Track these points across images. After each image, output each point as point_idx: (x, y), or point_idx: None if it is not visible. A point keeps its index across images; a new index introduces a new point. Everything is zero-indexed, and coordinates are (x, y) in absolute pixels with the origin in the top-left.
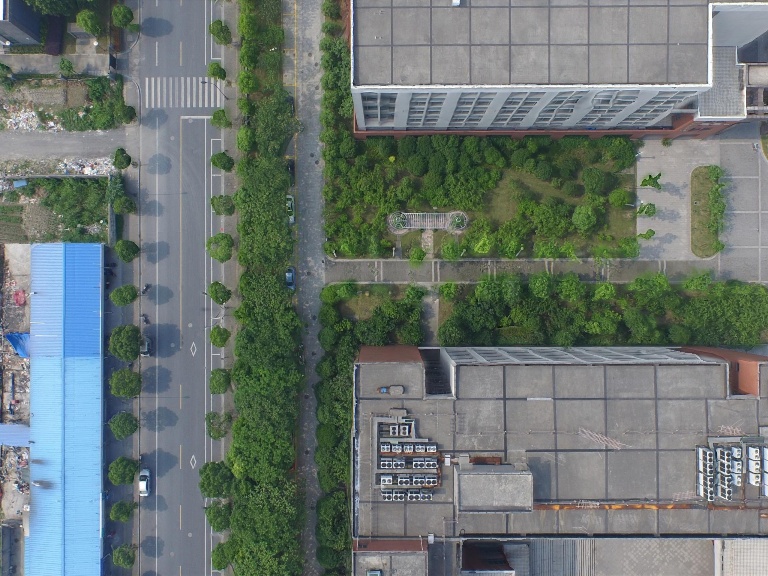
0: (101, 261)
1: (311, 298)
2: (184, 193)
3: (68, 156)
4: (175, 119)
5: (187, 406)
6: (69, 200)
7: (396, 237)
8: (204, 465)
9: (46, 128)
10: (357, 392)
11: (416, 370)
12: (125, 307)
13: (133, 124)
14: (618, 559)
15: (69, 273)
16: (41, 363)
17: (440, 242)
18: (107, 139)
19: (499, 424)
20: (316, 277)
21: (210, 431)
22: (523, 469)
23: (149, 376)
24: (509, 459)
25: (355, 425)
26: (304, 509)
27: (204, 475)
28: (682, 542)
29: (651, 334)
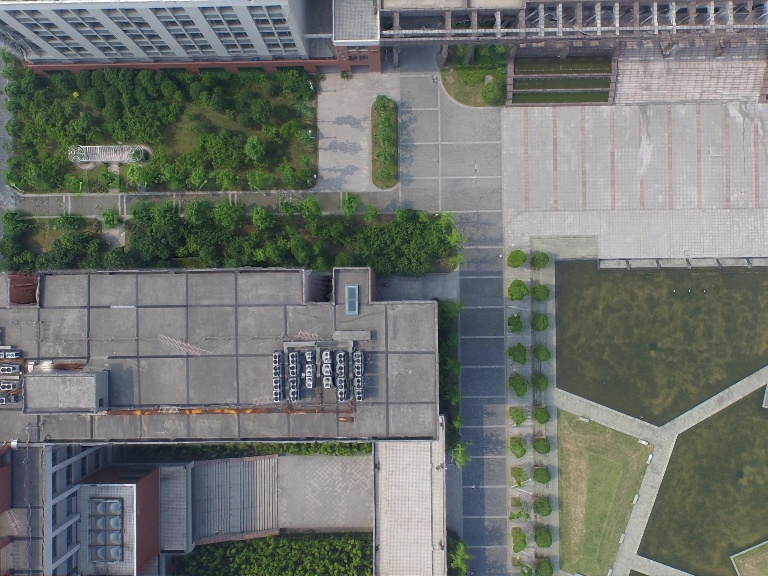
0: None
1: (0, 233)
2: None
3: None
4: None
5: None
6: None
7: (83, 172)
8: None
9: None
10: None
11: (2, 280)
12: None
13: None
14: (301, 487)
15: None
16: None
17: (126, 176)
18: None
19: (83, 332)
20: (6, 212)
21: None
22: (87, 371)
23: None
24: (87, 364)
25: None
26: None
27: None
28: (364, 469)
29: (314, 260)
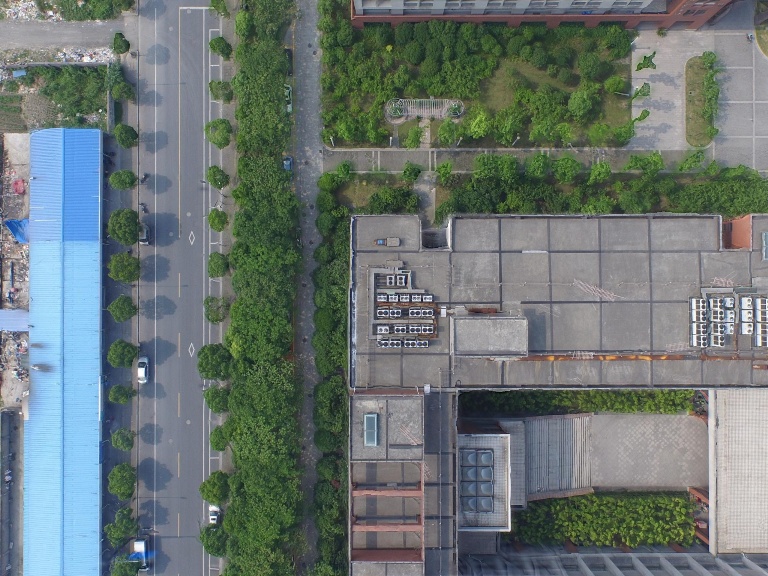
0: (100, 146)
1: (309, 187)
2: (182, 83)
3: (67, 46)
4: (174, 10)
5: (185, 295)
6: (68, 88)
7: (393, 127)
8: (202, 347)
9: (45, 17)
10: (354, 245)
11: (412, 223)
12: (124, 192)
13: (132, 13)
14: (613, 445)
15: (68, 158)
16: (40, 248)
17: (437, 132)
18: (106, 29)
19: (495, 276)
20: (314, 167)
21: (208, 314)
22: (518, 314)
23: (148, 265)
24: (504, 309)
25: (352, 278)
26: (302, 389)
27: (202, 354)
28: (677, 429)
29: None
